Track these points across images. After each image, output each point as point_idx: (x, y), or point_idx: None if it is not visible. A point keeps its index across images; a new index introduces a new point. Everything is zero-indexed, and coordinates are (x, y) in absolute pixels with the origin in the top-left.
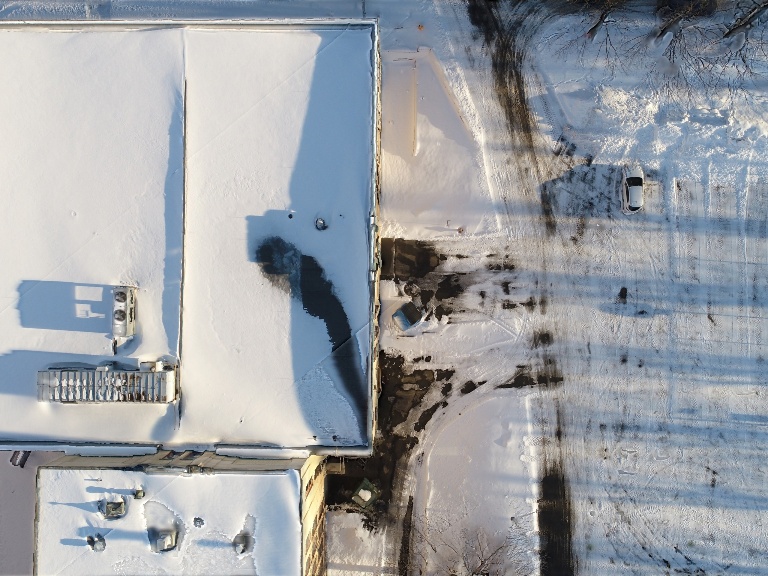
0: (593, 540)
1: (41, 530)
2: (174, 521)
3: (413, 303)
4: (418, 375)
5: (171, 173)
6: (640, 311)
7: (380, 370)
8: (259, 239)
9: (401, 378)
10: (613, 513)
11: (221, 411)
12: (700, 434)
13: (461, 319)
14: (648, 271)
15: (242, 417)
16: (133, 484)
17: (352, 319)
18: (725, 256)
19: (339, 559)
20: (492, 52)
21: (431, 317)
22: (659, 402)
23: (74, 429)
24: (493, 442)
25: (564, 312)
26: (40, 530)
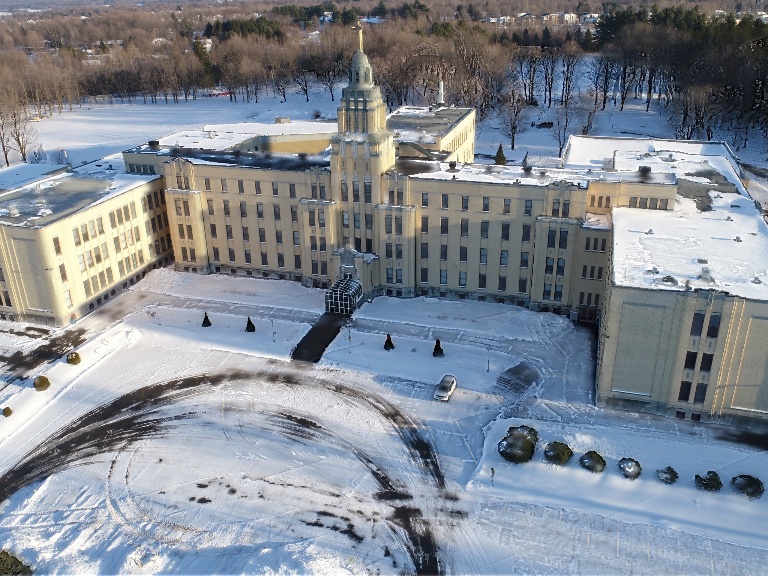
0: None
1: (617, 156)
2: None
3: None
4: None
5: None
6: None
7: None
8: None
9: None
10: None
11: None
12: None
13: None
14: None
15: None
16: None
17: None
18: None
19: None
20: (766, 179)
21: None
22: None
23: None
24: None
25: None
26: None
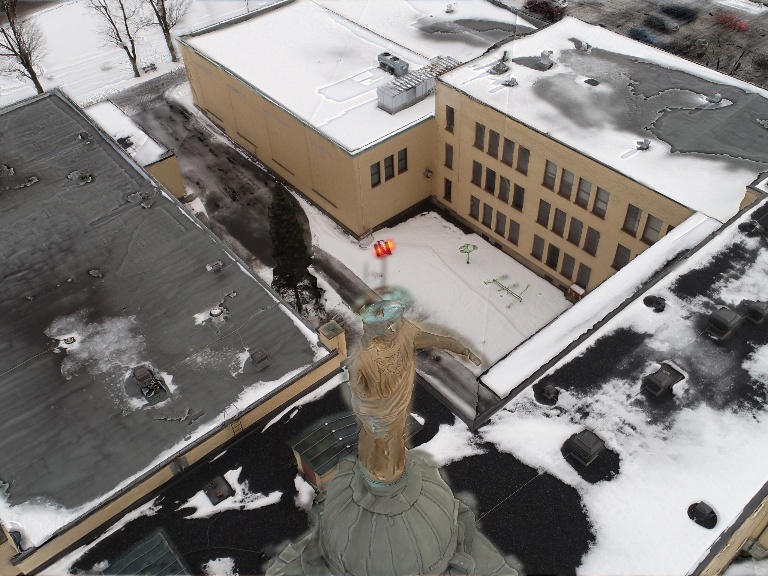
0: None
1: (472, 94)
2: (537, 59)
3: None
4: None
5: (354, 31)
6: (617, 26)
7: None
8: (427, 27)
9: None
10: None
11: None
12: None
13: None
14: (600, 16)
15: None
16: (495, 59)
17: (508, 22)
18: (620, 1)
19: None
20: None
21: None
22: None
23: None
24: None
25: None
26: (472, 95)
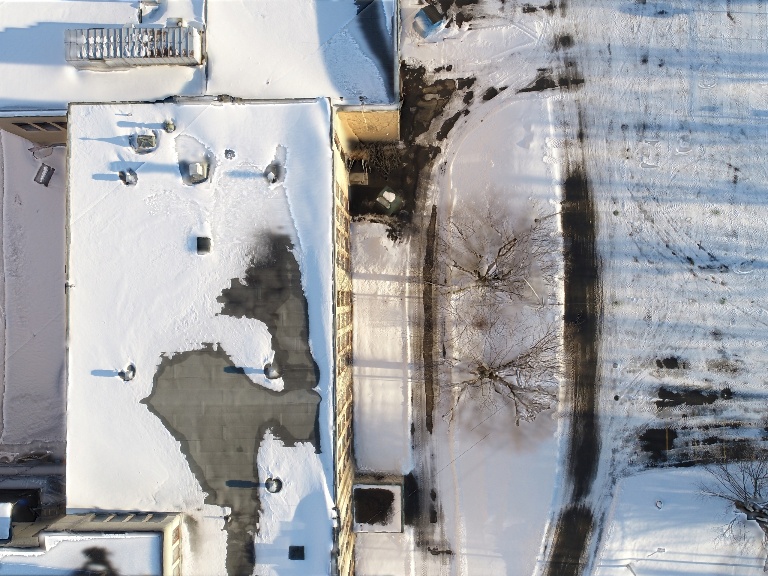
0: (617, 239)
1: (73, 166)
2: (205, 154)
3: (434, 5)
4: (439, 85)
5: None
6: (660, 11)
7: (401, 80)
8: None
9: (422, 89)
10: (636, 212)
11: (248, 73)
12: (721, 131)
13: (481, 25)
14: None
15: (269, 79)
16: (164, 118)
17: None
18: None
19: (364, 269)
20: None
21: (451, 24)
22: (680, 101)
23: (101, 96)
24: (516, 144)
25: (584, 14)
26: (72, 166)
